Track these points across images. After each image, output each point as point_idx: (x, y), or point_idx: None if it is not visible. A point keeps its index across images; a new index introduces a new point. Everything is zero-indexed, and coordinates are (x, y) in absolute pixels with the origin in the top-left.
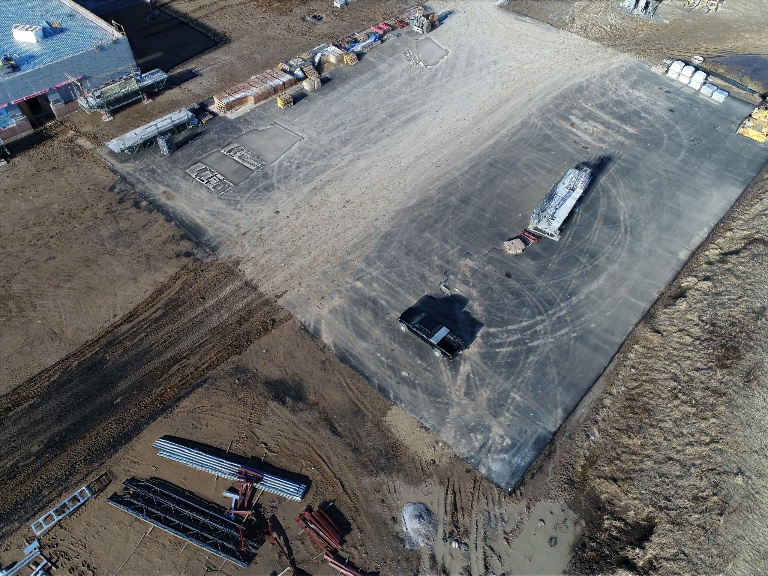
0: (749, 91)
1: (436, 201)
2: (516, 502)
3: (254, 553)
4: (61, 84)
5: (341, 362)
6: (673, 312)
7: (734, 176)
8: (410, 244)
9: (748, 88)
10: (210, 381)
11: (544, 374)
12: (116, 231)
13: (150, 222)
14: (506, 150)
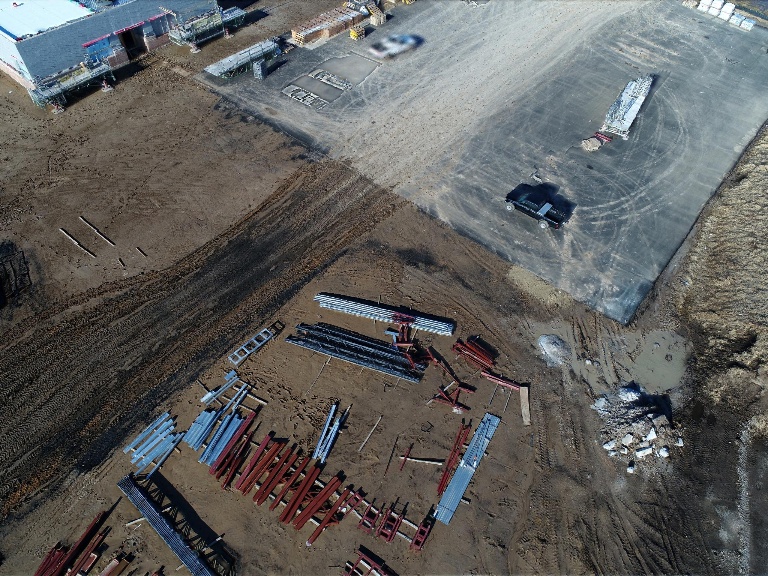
0: None
1: (513, 111)
2: (633, 331)
3: (422, 373)
4: (154, 17)
5: (460, 235)
6: (739, 190)
7: None
8: (499, 145)
9: None
10: (349, 252)
11: (637, 240)
12: (231, 141)
13: (260, 133)
14: (566, 70)
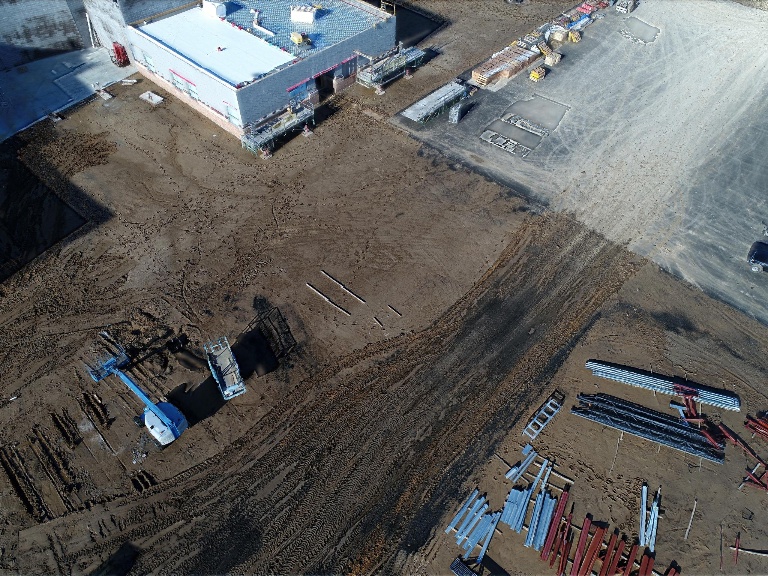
0: None
1: (722, 161)
2: None
3: (722, 452)
4: (346, 60)
5: (712, 298)
6: None
7: None
8: (719, 198)
9: None
10: (604, 315)
11: None
12: (445, 190)
13: (472, 182)
14: (761, 116)
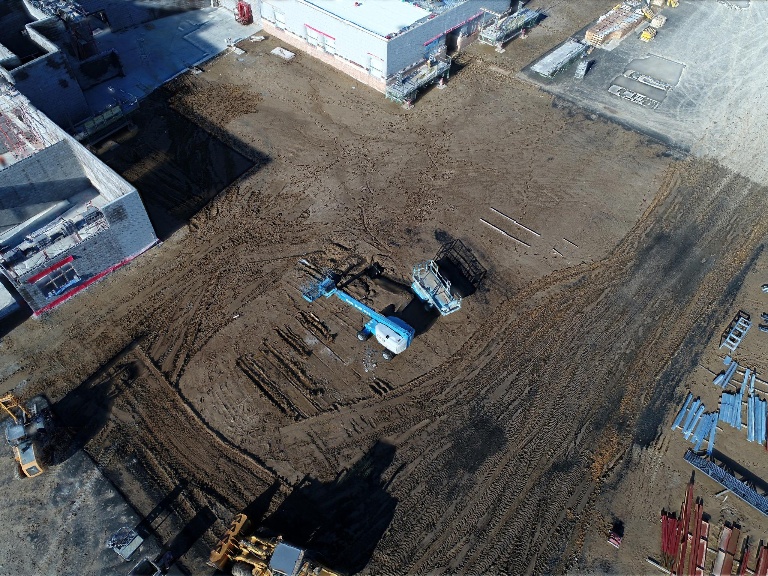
0: None
1: None
2: None
3: None
4: (472, 18)
5: None
6: None
7: None
8: None
9: None
10: (766, 247)
11: None
12: (587, 138)
13: (611, 131)
14: None
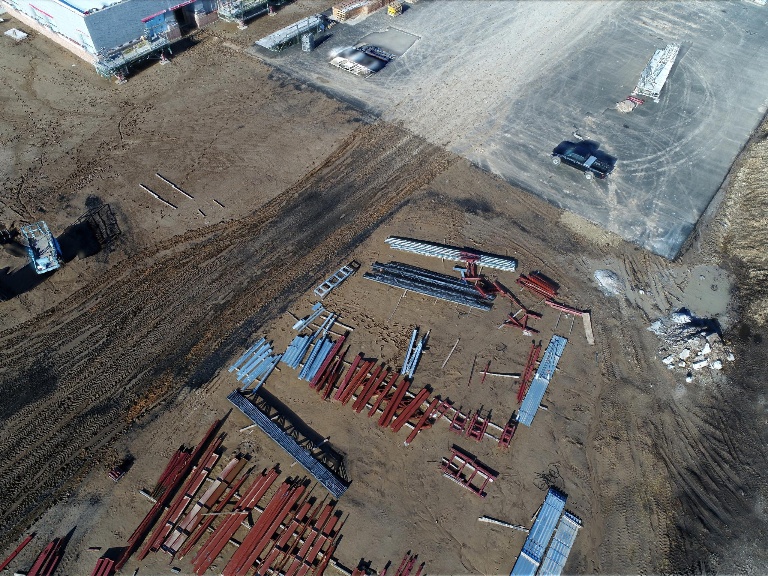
0: None
1: (550, 78)
2: (679, 266)
3: (491, 303)
4: None
5: (512, 186)
6: (766, 144)
7: None
8: (539, 108)
9: None
10: (411, 201)
11: (675, 188)
12: (288, 107)
13: (314, 99)
14: (595, 42)
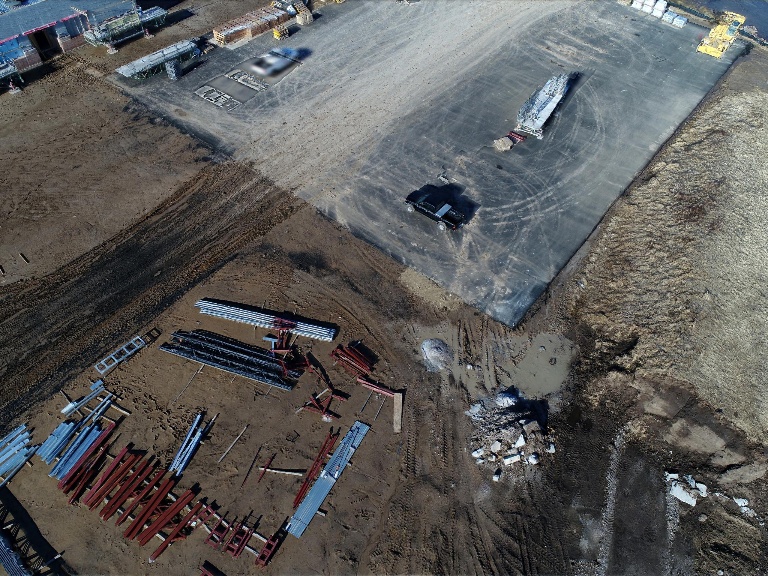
0: (706, 18)
1: (429, 111)
2: (520, 334)
3: (296, 380)
4: (67, 17)
5: (356, 237)
6: (646, 189)
7: (695, 86)
8: (409, 145)
9: (705, 16)
10: (240, 256)
11: (537, 240)
12: (135, 143)
13: (166, 135)
14: (490, 69)
